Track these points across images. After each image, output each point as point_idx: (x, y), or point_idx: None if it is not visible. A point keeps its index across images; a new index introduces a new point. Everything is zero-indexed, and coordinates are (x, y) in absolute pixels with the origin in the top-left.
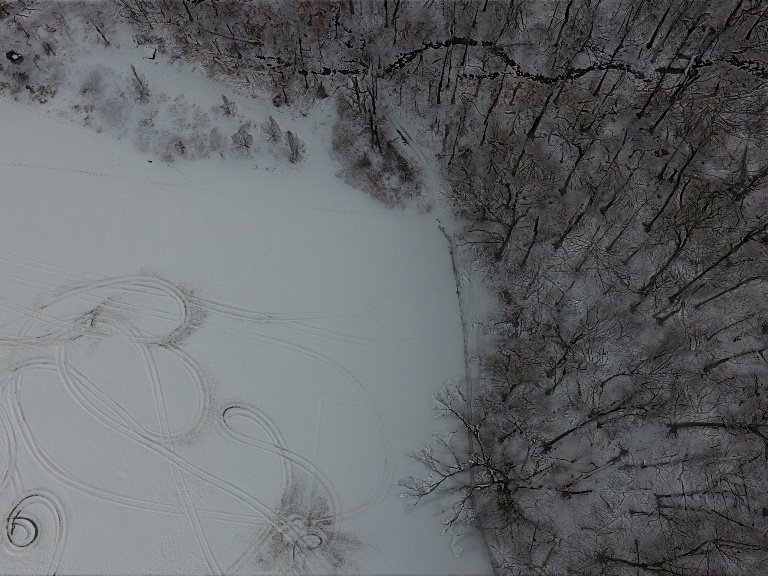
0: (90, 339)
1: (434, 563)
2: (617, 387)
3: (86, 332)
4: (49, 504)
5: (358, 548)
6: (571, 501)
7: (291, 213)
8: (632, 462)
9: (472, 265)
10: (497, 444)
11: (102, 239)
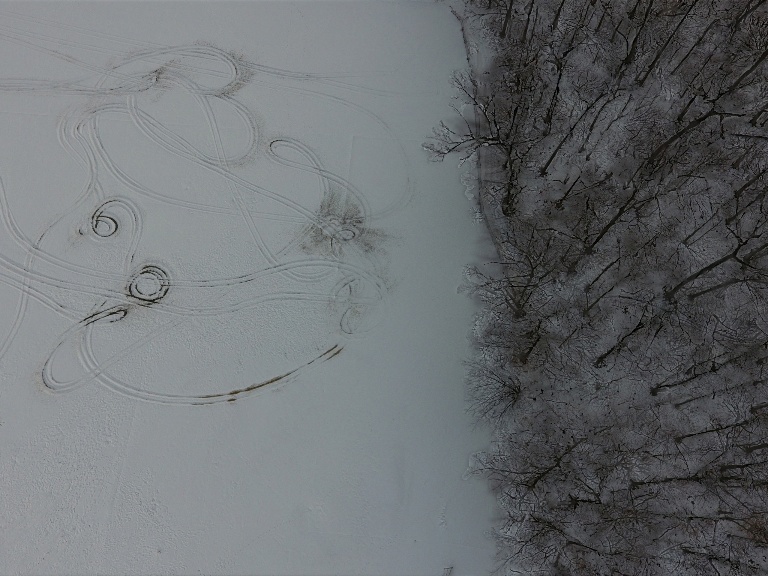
0: (156, 91)
1: (449, 250)
2: (603, 128)
3: (152, 86)
4: (126, 207)
5: (385, 239)
6: (564, 211)
7: (324, 1)
8: (615, 184)
9: (480, 32)
10: (501, 169)
11: (163, 18)
